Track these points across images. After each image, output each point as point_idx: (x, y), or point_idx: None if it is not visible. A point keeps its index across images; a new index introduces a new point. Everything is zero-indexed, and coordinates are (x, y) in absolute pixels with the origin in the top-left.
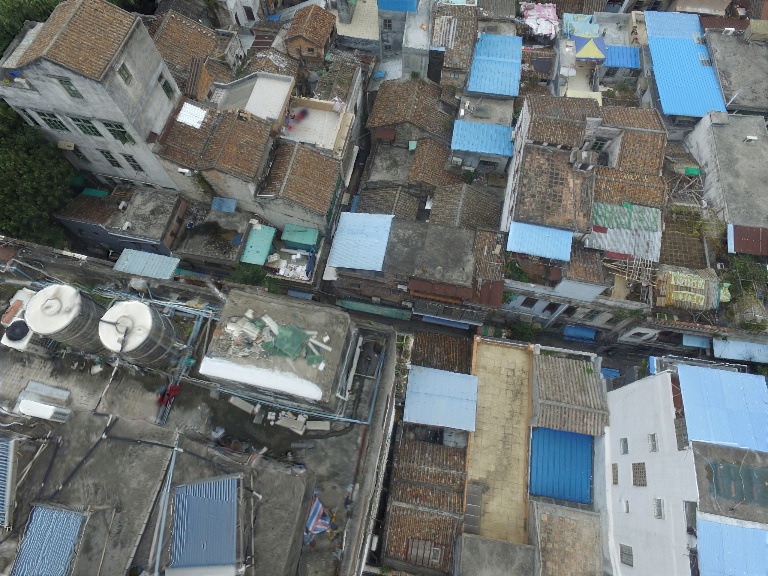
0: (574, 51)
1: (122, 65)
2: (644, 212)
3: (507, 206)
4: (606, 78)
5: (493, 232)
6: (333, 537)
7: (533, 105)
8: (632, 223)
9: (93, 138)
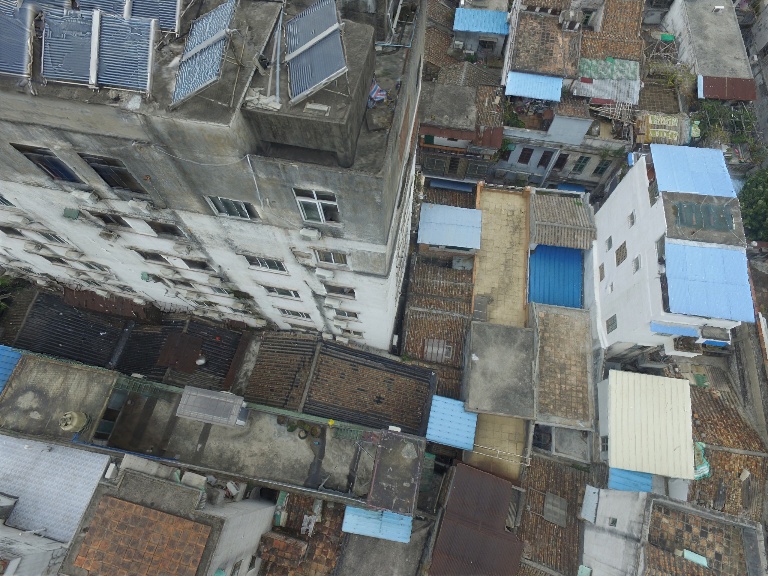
0: None
1: None
2: (625, 65)
3: (504, 74)
4: None
5: (493, 86)
6: (389, 104)
7: None
8: (614, 74)
9: None
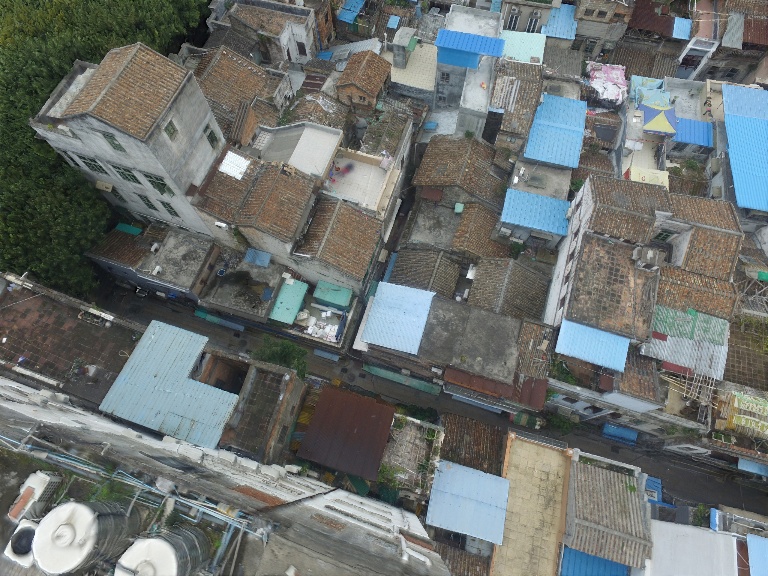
0: (642, 122)
1: (169, 121)
2: (710, 322)
3: (556, 291)
4: (673, 152)
5: (541, 325)
6: None
7: (597, 189)
8: (695, 333)
9: (132, 184)
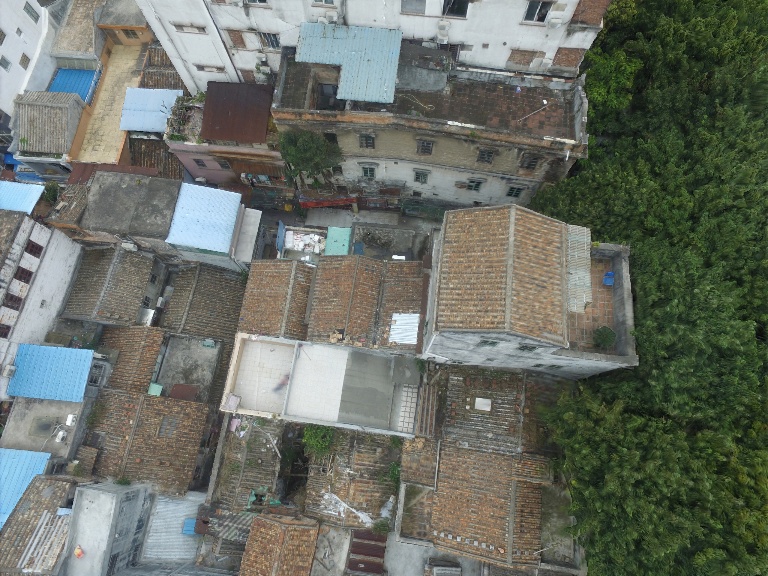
0: None
1: None
2: None
3: (46, 280)
4: None
5: (59, 219)
6: None
7: None
8: None
9: None
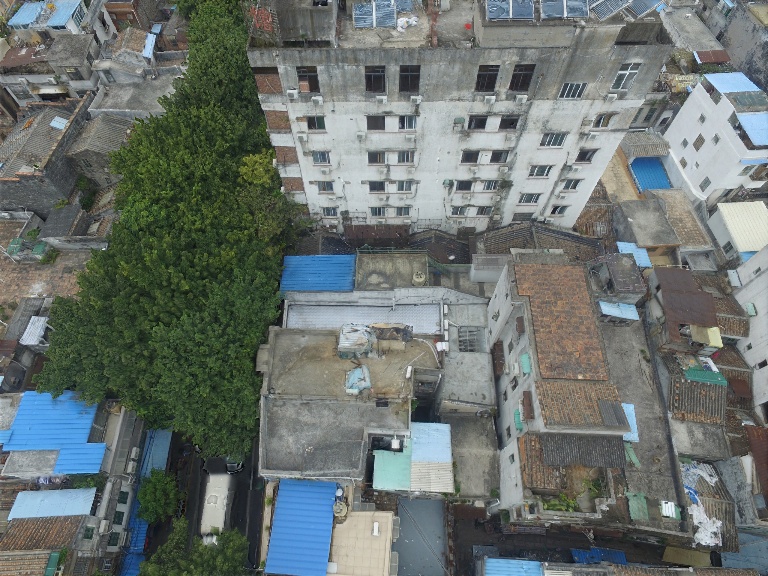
0: None
1: None
2: None
3: None
4: None
5: None
6: None
7: None
8: None
9: None
